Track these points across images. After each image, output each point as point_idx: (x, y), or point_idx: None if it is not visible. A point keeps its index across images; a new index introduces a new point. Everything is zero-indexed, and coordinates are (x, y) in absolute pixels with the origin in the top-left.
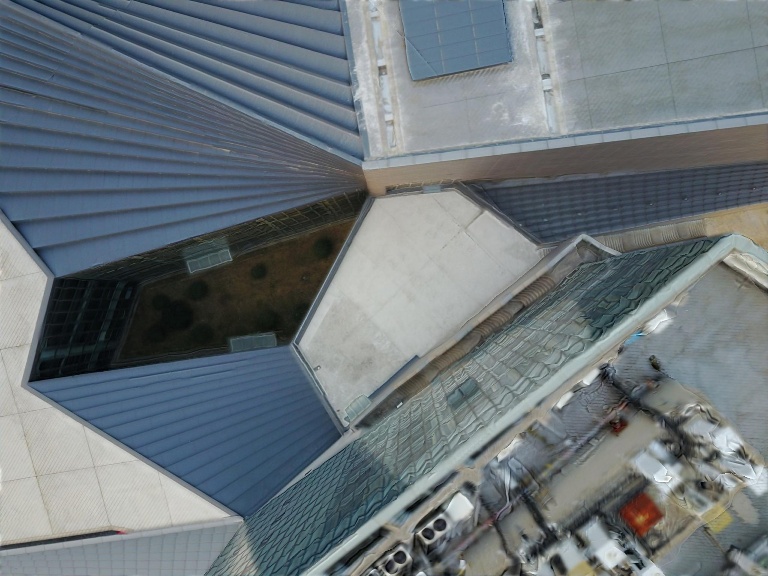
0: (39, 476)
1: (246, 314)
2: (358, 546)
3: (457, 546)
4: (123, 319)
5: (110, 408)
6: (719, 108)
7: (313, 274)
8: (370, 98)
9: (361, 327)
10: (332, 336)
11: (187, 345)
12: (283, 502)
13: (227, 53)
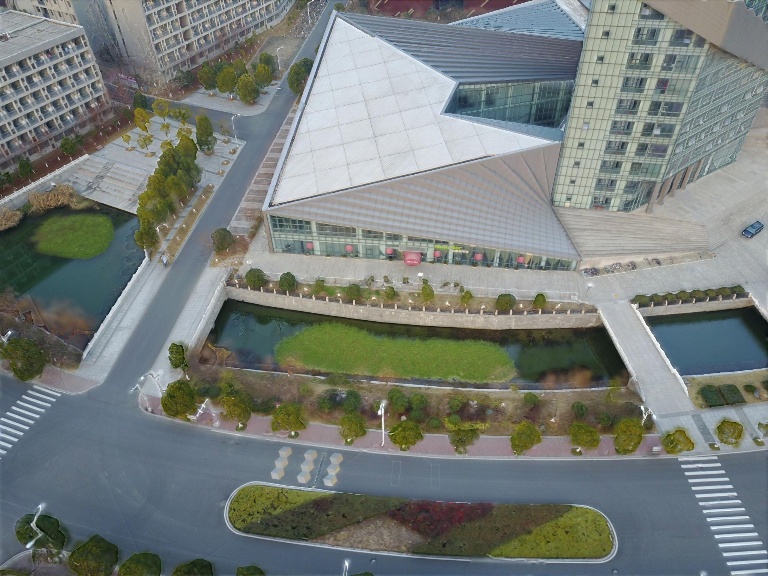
0: (447, 142)
1: None
2: None
3: None
4: None
5: None
6: None
7: None
8: None
9: None
10: None
11: None
12: None
13: None
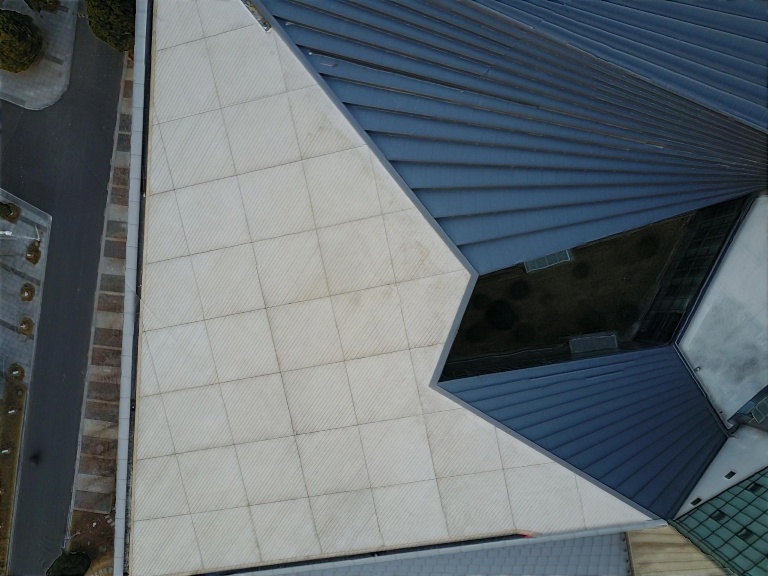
0: (440, 478)
1: (567, 315)
2: None
3: None
4: None
5: (518, 409)
6: None
7: (634, 274)
8: None
9: (742, 328)
10: (713, 337)
11: (507, 346)
12: (767, 505)
13: (685, 48)
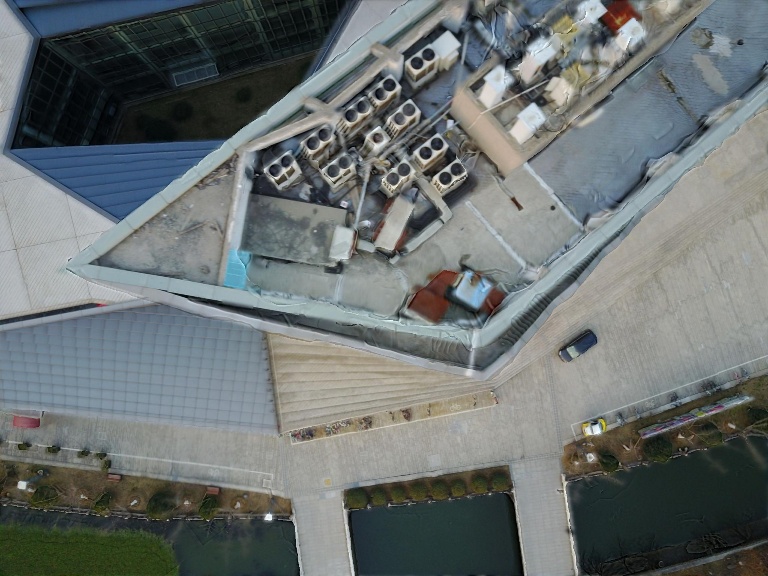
0: (19, 249)
1: None
2: (350, 67)
3: (444, 82)
4: (106, 137)
5: (94, 179)
6: None
7: None
8: None
9: None
10: None
11: None
12: None
13: None
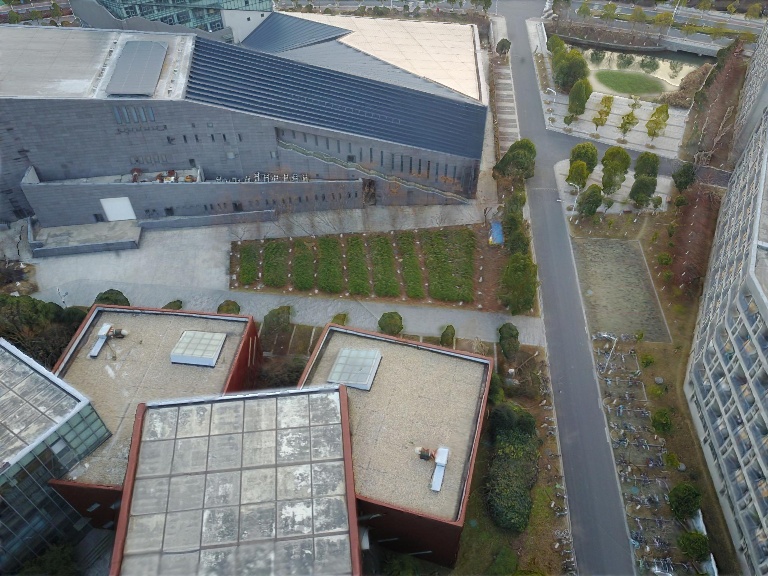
0: None
1: None
2: None
3: None
4: None
5: None
6: (55, 30)
7: None
8: (188, 45)
9: None
10: None
11: None
12: None
13: None
